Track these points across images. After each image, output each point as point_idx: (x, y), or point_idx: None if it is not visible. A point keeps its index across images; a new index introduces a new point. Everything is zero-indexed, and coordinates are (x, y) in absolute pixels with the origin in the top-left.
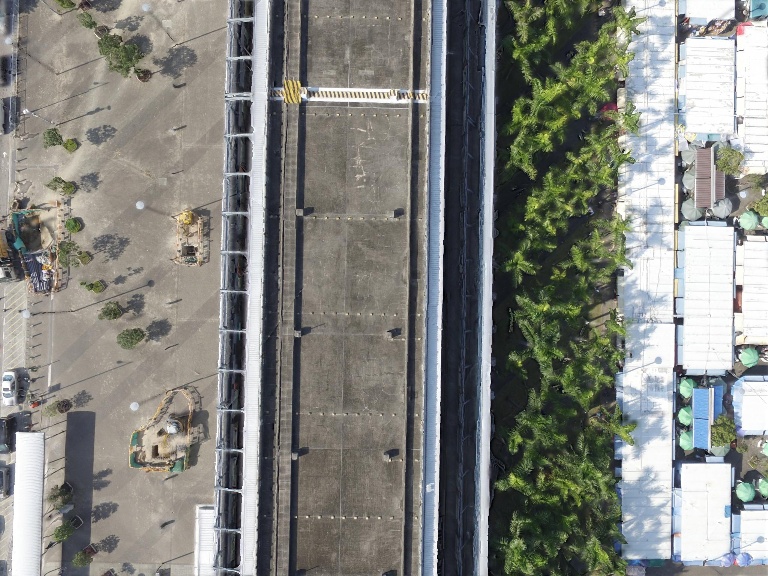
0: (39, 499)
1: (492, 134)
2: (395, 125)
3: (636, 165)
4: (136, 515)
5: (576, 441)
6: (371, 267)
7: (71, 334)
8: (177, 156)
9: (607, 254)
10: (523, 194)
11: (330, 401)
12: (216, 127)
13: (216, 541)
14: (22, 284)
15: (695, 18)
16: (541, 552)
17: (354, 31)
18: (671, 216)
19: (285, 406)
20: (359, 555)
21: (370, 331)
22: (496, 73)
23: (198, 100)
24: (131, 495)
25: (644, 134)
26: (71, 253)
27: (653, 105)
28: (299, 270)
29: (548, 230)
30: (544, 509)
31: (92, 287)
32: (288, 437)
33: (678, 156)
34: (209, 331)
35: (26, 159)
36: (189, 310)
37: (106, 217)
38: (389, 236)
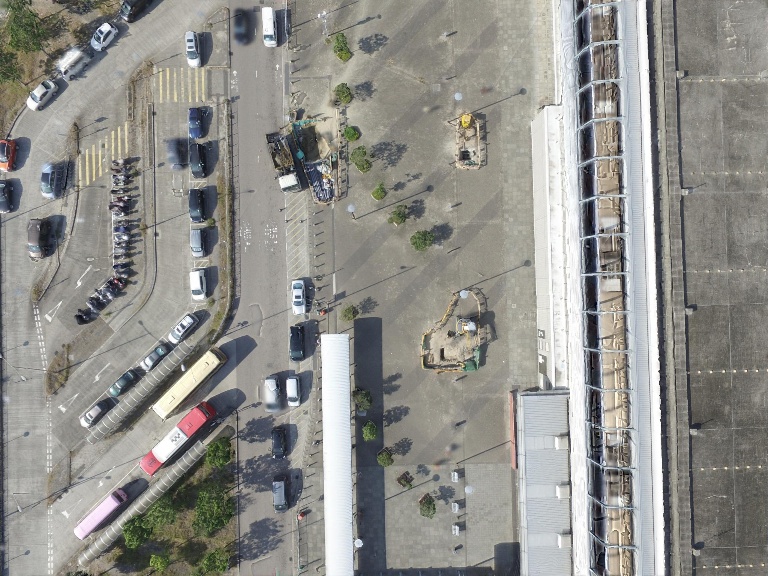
0: (348, 400)
1: None
2: None
3: None
4: (428, 417)
5: None
6: (746, 127)
7: (353, 242)
8: (449, 62)
9: None
10: None
11: (715, 258)
12: (487, 32)
13: (583, 410)
14: (302, 195)
15: None
16: None
17: None
18: None
19: (676, 263)
20: (751, 407)
21: (749, 189)
22: None
23: (467, 6)
24: (422, 398)
25: None
26: None
27: None
28: None
29: None
30: None
31: None
32: (681, 293)
33: None
34: (491, 233)
35: (299, 71)
36: (469, 213)
37: (382, 125)
38: (762, 96)
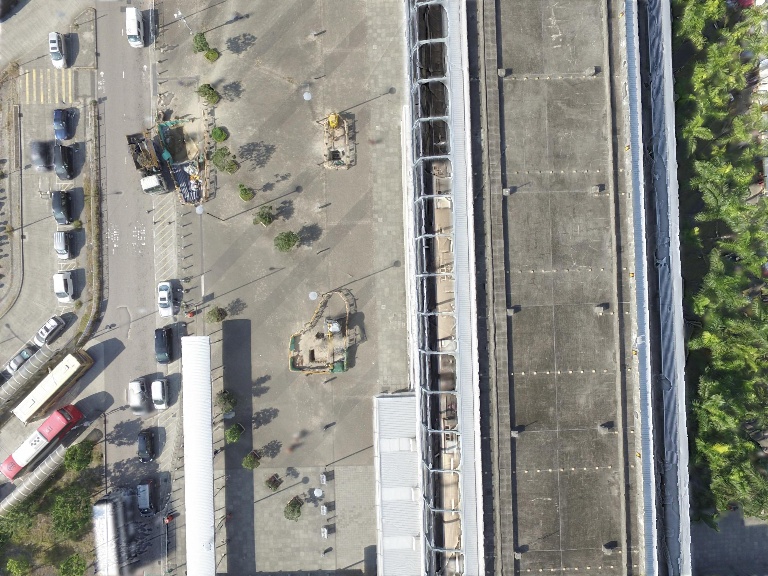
0: (208, 402)
1: None
2: None
3: None
4: (297, 419)
5: (750, 308)
6: (572, 125)
7: (222, 243)
8: (318, 61)
9: None
10: (687, 67)
11: (539, 258)
12: (356, 31)
13: (419, 413)
14: (170, 196)
15: None
16: (731, 412)
17: None
18: None
19: (498, 264)
20: (576, 408)
21: (574, 188)
22: None
23: (336, 5)
24: (291, 400)
25: None
26: (226, 157)
27: None
28: (501, 131)
29: (715, 100)
30: (727, 373)
31: (246, 192)
32: (502, 294)
33: None
34: (360, 233)
35: (167, 71)
36: (339, 214)
37: (251, 125)
38: (588, 94)
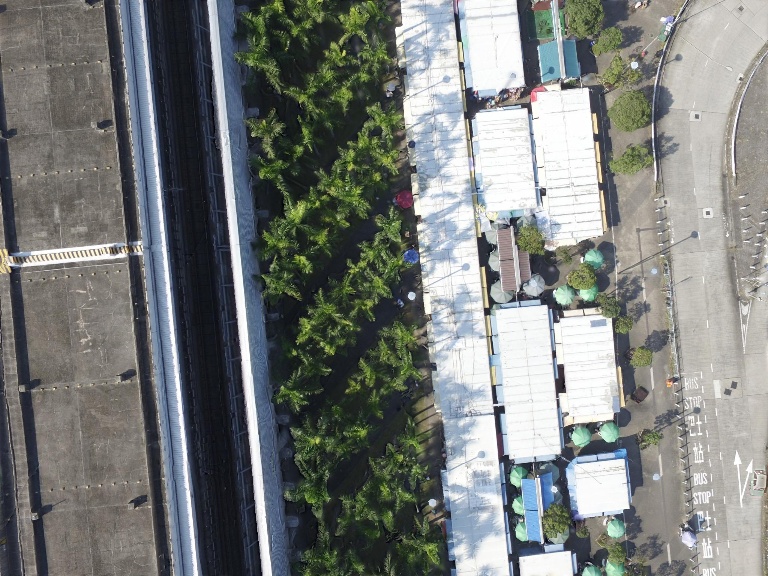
0: None
1: (239, 266)
2: (116, 281)
3: (437, 253)
4: None
5: (383, 563)
6: (108, 434)
7: None
8: None
9: (398, 362)
10: (298, 313)
11: None
12: None
13: None
14: None
15: (483, 90)
16: None
17: (61, 187)
18: (480, 302)
19: None
20: None
21: (114, 502)
22: (257, 188)
23: None
24: None
25: (442, 220)
26: None
27: (448, 188)
28: (33, 446)
29: (325, 350)
30: None
31: None
32: None
33: (481, 237)
34: None
35: None
36: None
37: None
38: (123, 399)
